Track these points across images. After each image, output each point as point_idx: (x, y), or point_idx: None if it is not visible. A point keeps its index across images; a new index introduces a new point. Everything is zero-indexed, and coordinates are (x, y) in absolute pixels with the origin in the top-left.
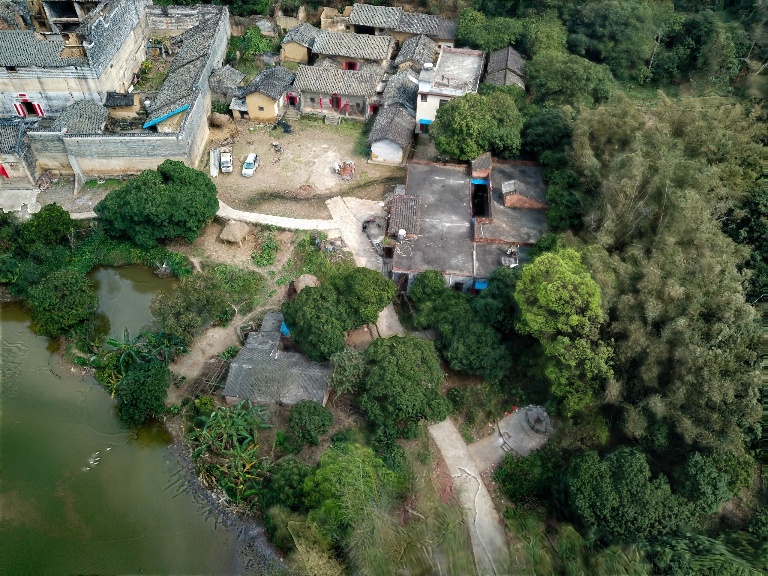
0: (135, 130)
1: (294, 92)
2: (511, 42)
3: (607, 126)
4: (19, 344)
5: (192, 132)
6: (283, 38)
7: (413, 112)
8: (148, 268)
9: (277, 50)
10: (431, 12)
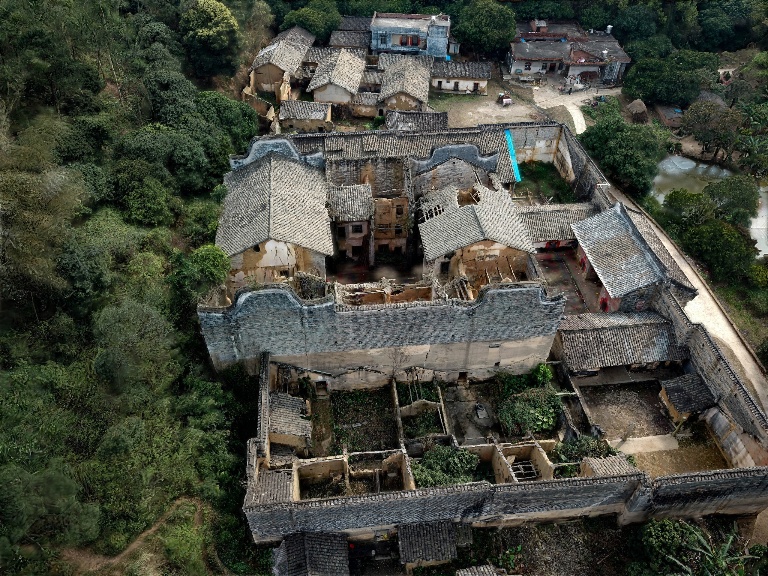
0: None
1: None
2: None
3: None
4: (763, 237)
5: None
6: None
7: None
8: None
9: None
10: None
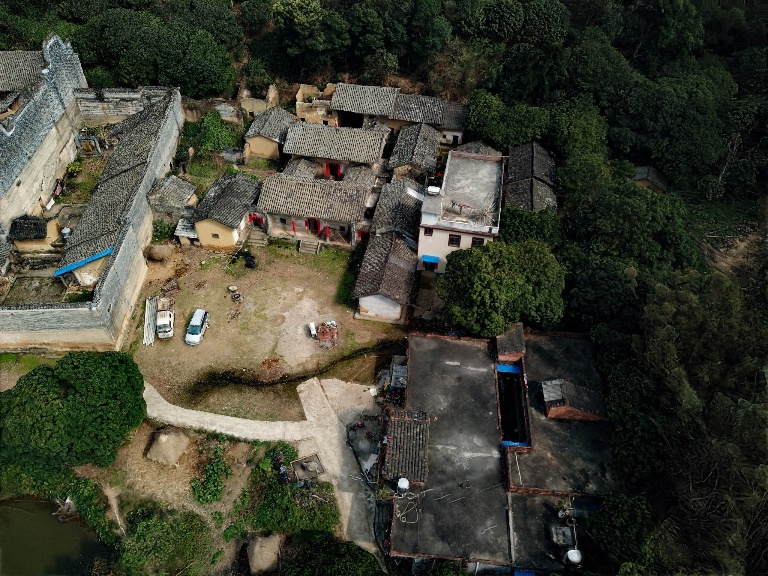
0: (49, 269)
1: (259, 212)
2: (536, 136)
3: (699, 320)
4: None
5: (116, 288)
6: (250, 123)
7: (414, 243)
8: (46, 502)
9: (242, 140)
10: (433, 90)
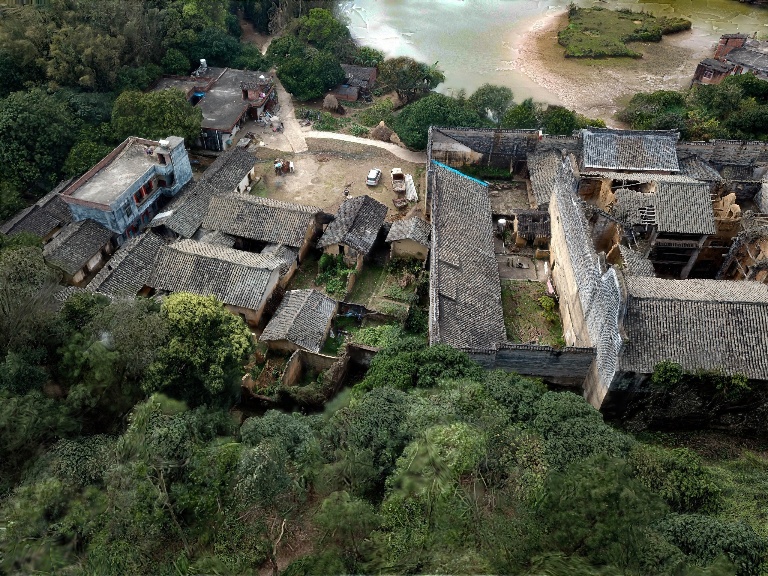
0: None
1: (323, 219)
2: None
3: None
4: None
5: None
6: None
7: None
8: None
9: None
10: None
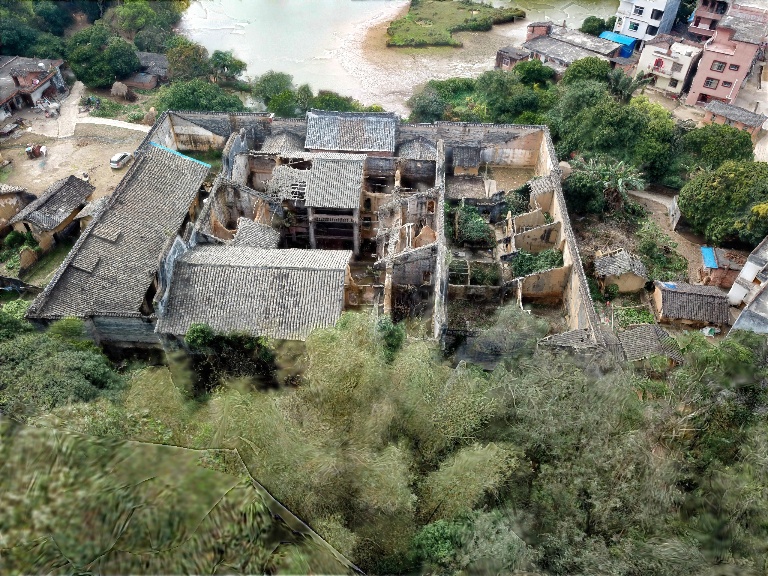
0: None
1: None
2: None
3: None
4: None
5: None
6: None
7: None
8: None
9: None
10: None
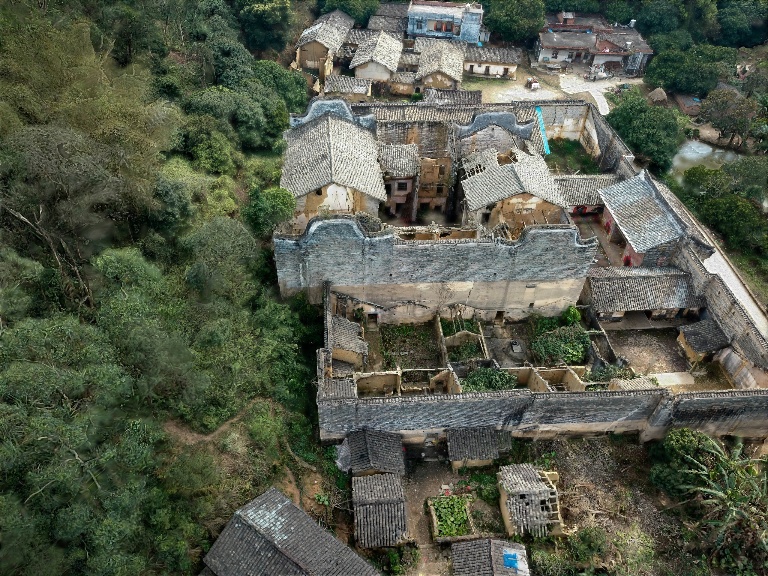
0: None
1: None
2: None
3: None
4: None
5: None
6: None
7: None
8: None
9: None
10: None
